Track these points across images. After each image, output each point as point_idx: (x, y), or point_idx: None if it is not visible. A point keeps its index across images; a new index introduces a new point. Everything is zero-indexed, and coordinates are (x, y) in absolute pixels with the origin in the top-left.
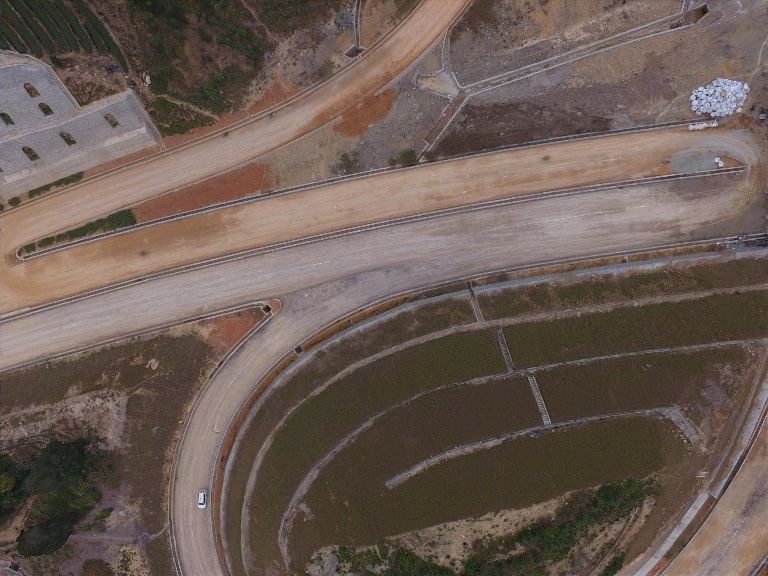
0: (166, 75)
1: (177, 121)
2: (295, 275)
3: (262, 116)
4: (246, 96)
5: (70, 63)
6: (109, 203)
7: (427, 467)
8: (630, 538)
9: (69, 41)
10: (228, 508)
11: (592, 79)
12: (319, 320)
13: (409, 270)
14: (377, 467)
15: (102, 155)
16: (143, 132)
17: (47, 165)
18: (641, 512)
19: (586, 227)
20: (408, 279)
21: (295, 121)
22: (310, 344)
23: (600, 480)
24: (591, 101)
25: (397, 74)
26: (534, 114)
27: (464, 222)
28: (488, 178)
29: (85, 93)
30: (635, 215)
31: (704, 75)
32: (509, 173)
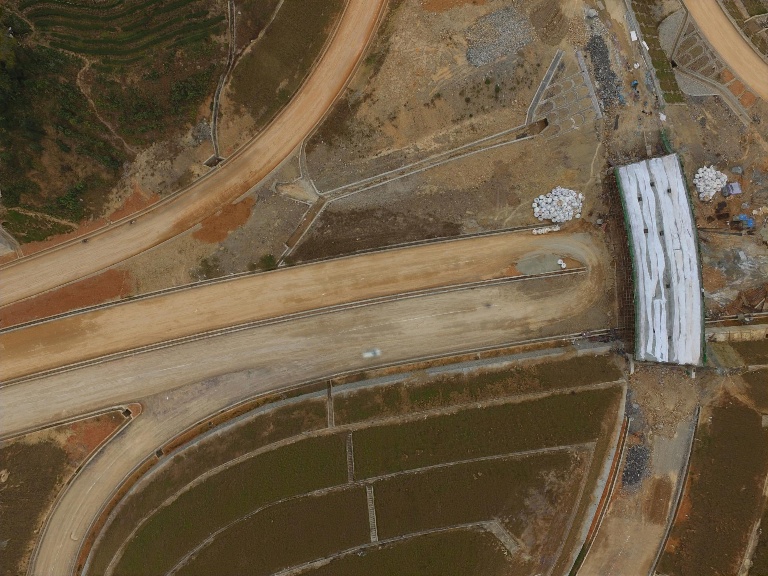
0: (18, 188)
1: (33, 230)
2: (156, 378)
3: (122, 223)
4: (106, 203)
5: None
6: None
7: None
8: None
9: None
10: None
11: (444, 186)
12: (180, 422)
13: (270, 371)
14: None
15: None
16: None
17: None
18: None
19: (441, 326)
20: (269, 380)
21: (155, 228)
22: (171, 447)
23: None
24: (442, 208)
25: (255, 183)
26: (388, 220)
27: (323, 323)
28: (346, 281)
29: None
30: (486, 314)
31: (546, 183)
32: (366, 276)
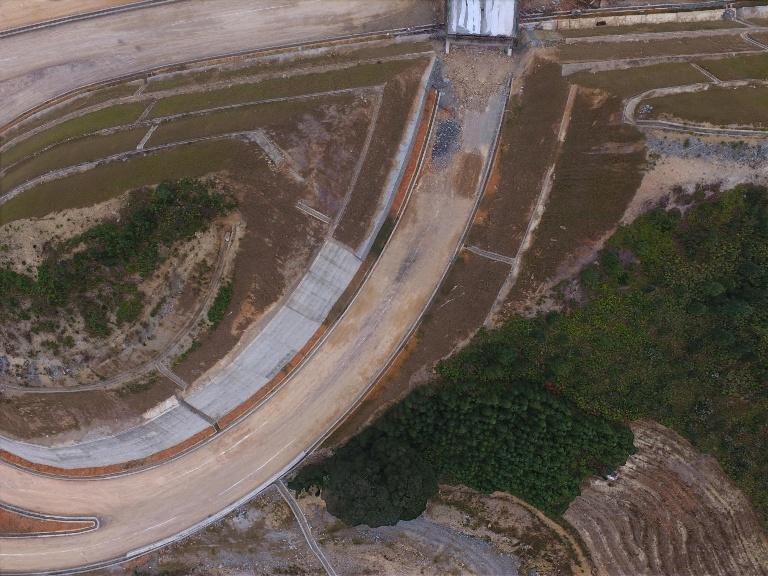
0: None
1: None
2: None
3: None
4: None
5: None
6: None
7: (23, 191)
8: (230, 265)
9: None
10: None
11: None
12: (8, 114)
13: (94, 64)
14: None
15: None
16: None
17: None
18: (235, 236)
19: (262, 21)
20: (93, 73)
21: None
22: None
23: (159, 180)
24: None
25: None
26: None
27: (145, 17)
28: None
29: None
30: (309, 9)
31: None
32: None
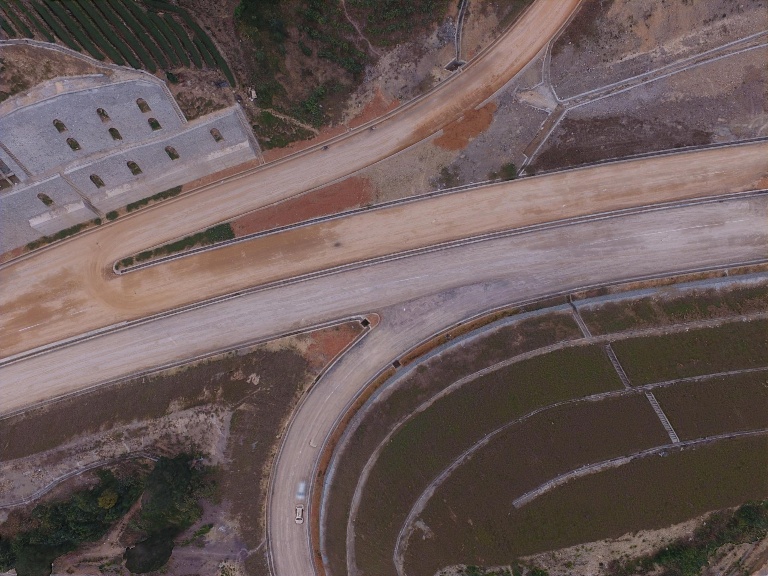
0: (271, 89)
1: (278, 135)
2: (393, 289)
3: (362, 130)
4: (345, 110)
5: (182, 78)
6: (207, 217)
7: (555, 486)
8: (756, 557)
9: (180, 56)
10: (329, 524)
11: (691, 92)
12: (417, 334)
13: (508, 284)
14: (501, 485)
15: (203, 169)
16: (246, 146)
17: (149, 179)
18: None
19: (686, 241)
20: (507, 293)
21: (395, 135)
22: (408, 358)
23: (739, 500)
24: (692, 115)
25: (498, 88)
26: (634, 128)
27: (563, 236)
28: (587, 192)
29: (194, 108)
30: (735, 229)
31: None
32: (609, 187)
